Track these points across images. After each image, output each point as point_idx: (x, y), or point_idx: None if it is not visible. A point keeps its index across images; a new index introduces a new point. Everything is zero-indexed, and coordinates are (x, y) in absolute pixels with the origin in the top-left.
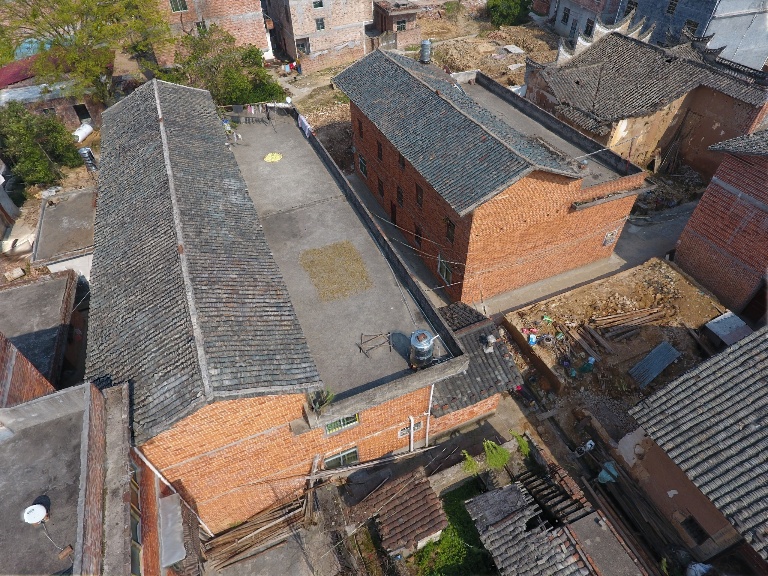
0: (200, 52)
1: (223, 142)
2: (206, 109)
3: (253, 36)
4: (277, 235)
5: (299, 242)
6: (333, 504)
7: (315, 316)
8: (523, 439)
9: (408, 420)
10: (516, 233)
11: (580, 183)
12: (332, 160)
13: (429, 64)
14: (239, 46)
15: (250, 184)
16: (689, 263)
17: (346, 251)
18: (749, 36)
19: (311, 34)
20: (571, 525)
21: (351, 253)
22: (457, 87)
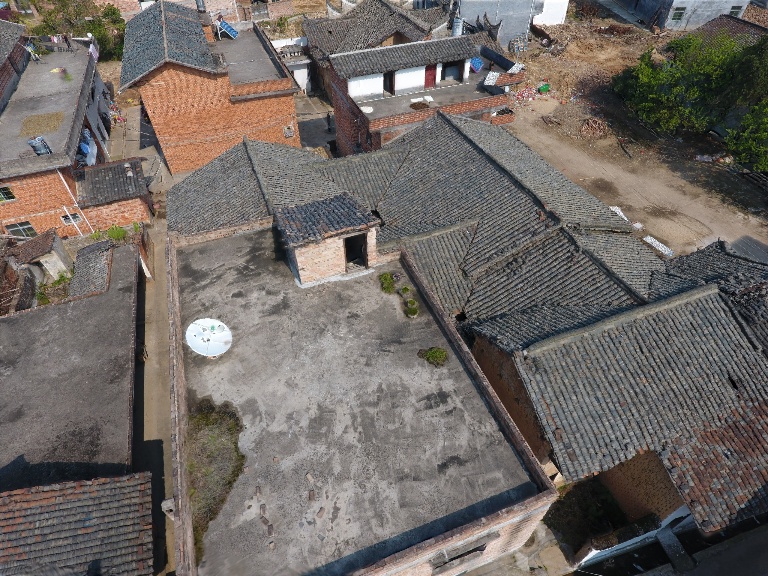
0: (60, 7)
1: (4, 52)
2: (11, 35)
3: (125, 0)
4: (21, 108)
5: (32, 111)
6: (0, 247)
7: (8, 143)
8: (137, 225)
9: (63, 209)
10: (190, 115)
11: (227, 80)
12: (85, 68)
13: (205, 13)
14: (99, 5)
15: (28, 84)
16: (341, 150)
17: (56, 116)
18: (504, 4)
19: (183, 2)
20: (115, 248)
21: (59, 117)
22: (225, 31)
